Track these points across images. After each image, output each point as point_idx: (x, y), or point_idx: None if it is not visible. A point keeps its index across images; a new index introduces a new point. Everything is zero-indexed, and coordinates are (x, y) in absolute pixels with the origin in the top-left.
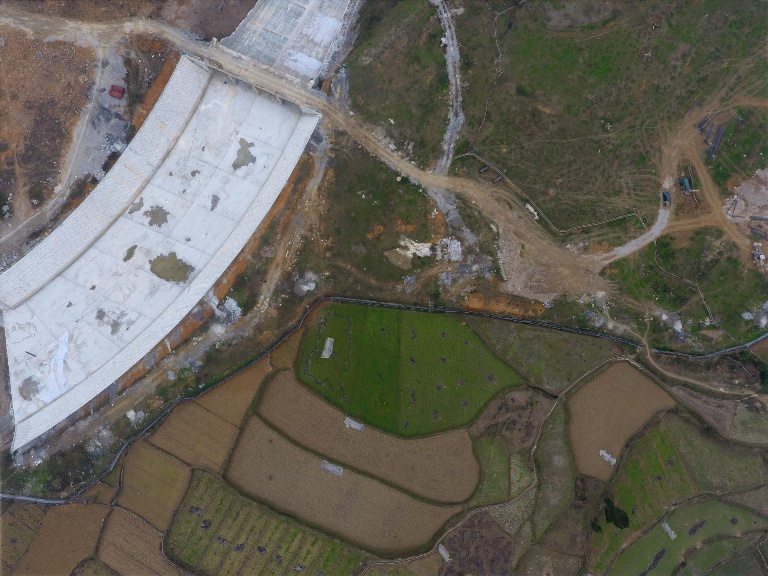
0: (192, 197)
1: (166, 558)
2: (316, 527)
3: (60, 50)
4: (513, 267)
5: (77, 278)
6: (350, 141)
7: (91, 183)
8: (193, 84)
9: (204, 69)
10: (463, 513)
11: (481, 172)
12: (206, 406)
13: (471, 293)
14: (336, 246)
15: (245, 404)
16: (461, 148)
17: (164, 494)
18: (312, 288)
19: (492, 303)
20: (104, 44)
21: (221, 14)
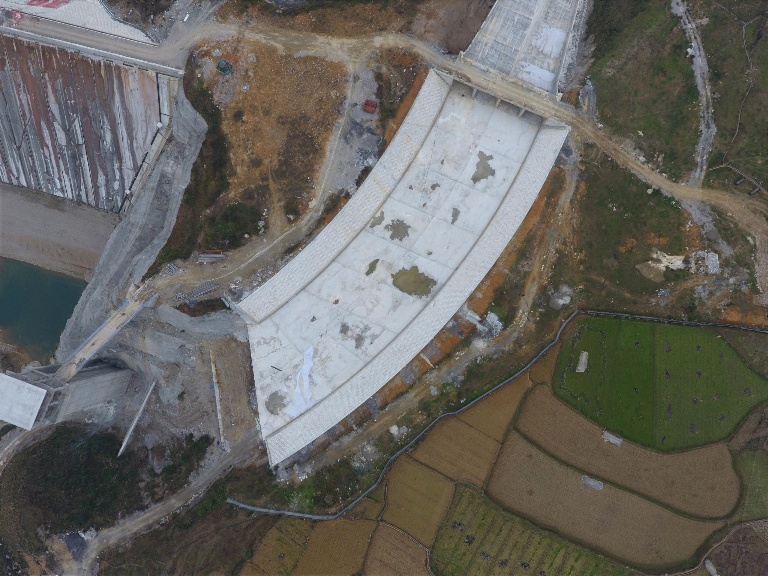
0: (432, 210)
1: (432, 574)
2: (578, 542)
3: (311, 65)
4: None
5: (320, 292)
6: (599, 153)
7: (344, 198)
8: (436, 97)
9: (446, 82)
10: (727, 528)
11: (737, 184)
12: (467, 421)
13: (727, 306)
14: (588, 259)
15: (506, 419)
16: (715, 160)
17: (428, 509)
18: (567, 302)
19: (750, 316)
20: (354, 59)
21: (461, 27)
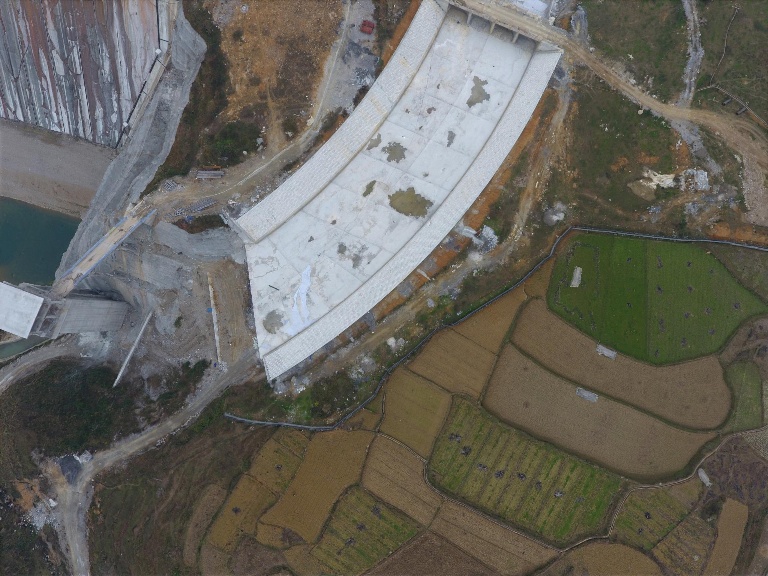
0: (429, 133)
1: (430, 484)
2: (574, 453)
3: None
4: (757, 197)
5: (318, 213)
6: (591, 76)
7: (342, 116)
8: (431, 22)
9: (441, 8)
10: (719, 438)
11: (725, 104)
12: (464, 333)
13: (717, 222)
14: (581, 178)
15: (502, 331)
16: (703, 81)
17: (426, 421)
18: (561, 218)
19: (738, 232)
20: None
21: None
